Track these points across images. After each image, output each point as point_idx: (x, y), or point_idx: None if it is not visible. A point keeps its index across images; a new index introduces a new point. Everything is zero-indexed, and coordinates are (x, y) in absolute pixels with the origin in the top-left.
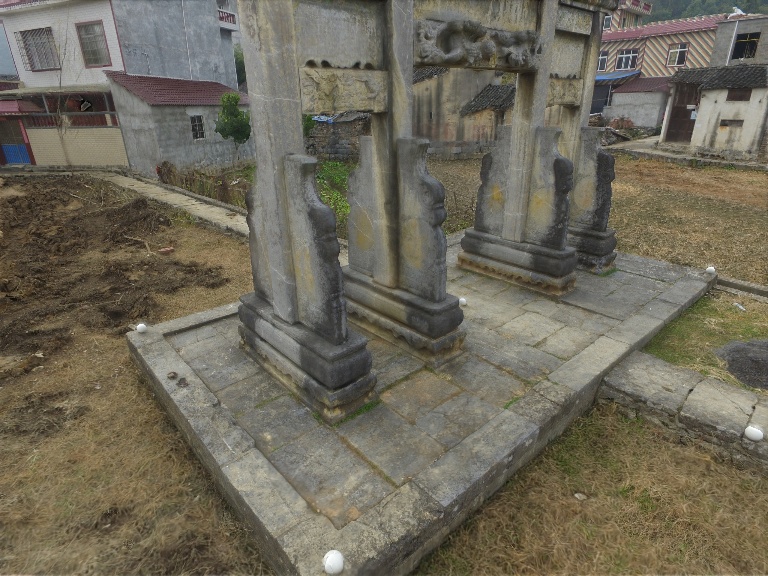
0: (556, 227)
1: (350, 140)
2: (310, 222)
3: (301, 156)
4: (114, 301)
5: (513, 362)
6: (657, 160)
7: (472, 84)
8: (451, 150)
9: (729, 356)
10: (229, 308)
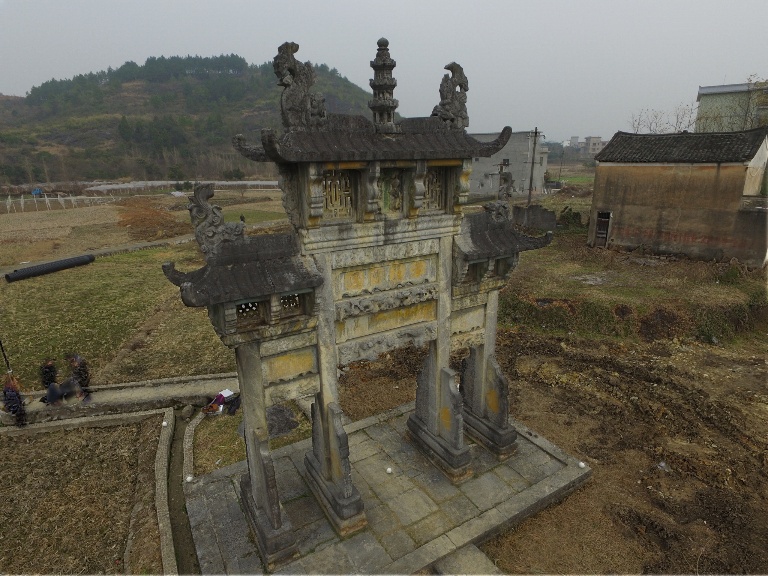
0: None
1: None
2: None
3: None
4: (697, 568)
5: None
6: None
7: None
8: None
9: None
10: (546, 487)
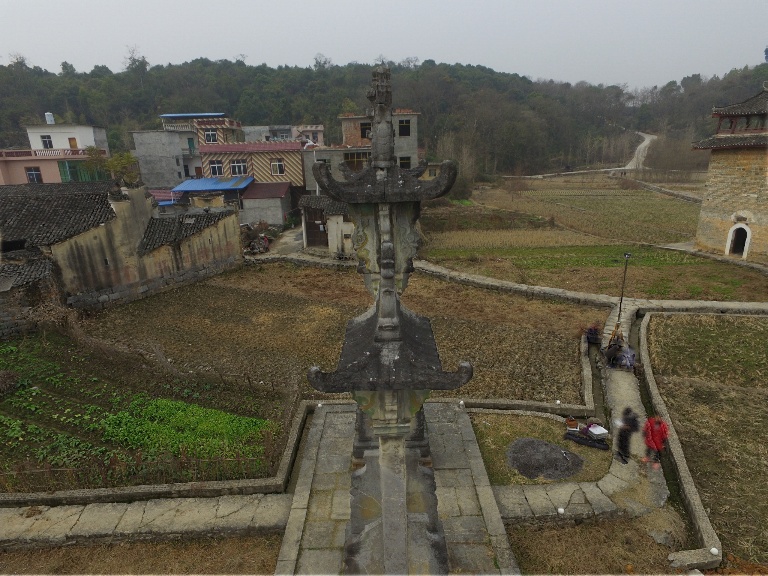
0: (419, 429)
1: (9, 311)
2: (433, 549)
3: (420, 517)
4: None
5: (468, 535)
6: (315, 267)
7: (139, 223)
8: (137, 290)
9: (515, 465)
10: None
